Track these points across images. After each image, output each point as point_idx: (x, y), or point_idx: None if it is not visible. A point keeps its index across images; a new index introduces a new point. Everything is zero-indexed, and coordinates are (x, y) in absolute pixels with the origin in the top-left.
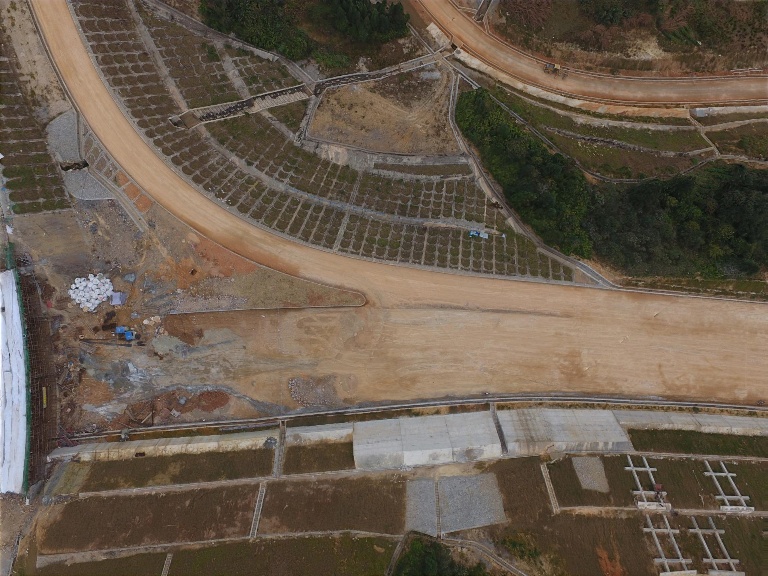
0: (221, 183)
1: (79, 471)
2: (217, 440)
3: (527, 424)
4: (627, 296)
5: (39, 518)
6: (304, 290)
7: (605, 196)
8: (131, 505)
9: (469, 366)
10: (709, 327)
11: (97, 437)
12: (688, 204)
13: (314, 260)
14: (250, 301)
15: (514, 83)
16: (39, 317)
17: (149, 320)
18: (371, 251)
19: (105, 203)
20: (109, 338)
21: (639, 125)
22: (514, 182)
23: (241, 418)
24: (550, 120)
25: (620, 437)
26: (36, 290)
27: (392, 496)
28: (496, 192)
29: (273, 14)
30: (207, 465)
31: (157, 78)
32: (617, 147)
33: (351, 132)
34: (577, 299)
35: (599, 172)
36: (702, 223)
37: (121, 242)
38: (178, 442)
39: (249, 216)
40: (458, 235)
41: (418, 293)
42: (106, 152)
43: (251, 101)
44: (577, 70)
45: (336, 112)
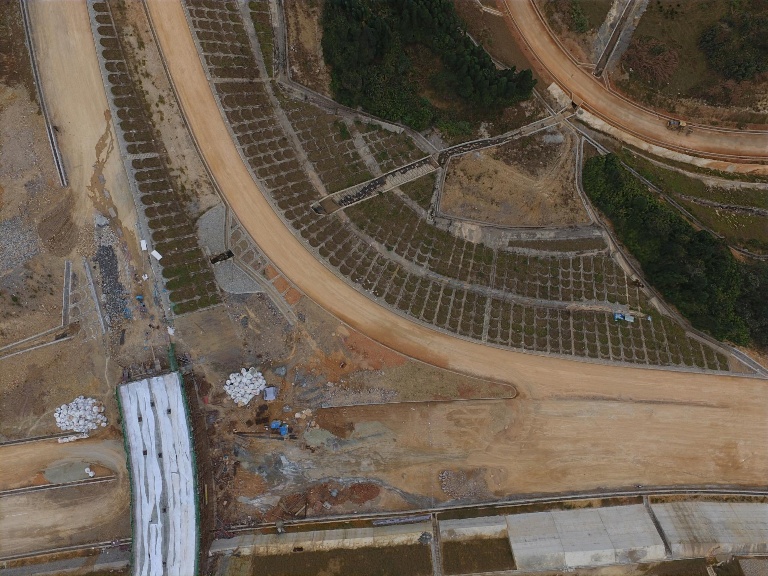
0: (366, 272)
1: (241, 567)
2: (372, 535)
3: (686, 521)
4: None
5: None
6: (454, 383)
7: (759, 278)
8: None
9: (621, 458)
10: None
11: (252, 529)
12: None
13: (463, 351)
14: (401, 394)
15: (639, 143)
16: (197, 413)
17: (301, 413)
18: (520, 341)
19: (255, 296)
20: (262, 431)
21: None
22: (656, 259)
23: (392, 510)
24: (683, 186)
25: None
26: (193, 387)
27: None
28: (634, 267)
29: (399, 85)
30: (366, 562)
31: (297, 164)
32: (756, 215)
33: (484, 208)
34: (734, 389)
35: (747, 248)
36: None
37: (271, 335)
38: (334, 536)
39: (397, 307)
40: (603, 319)
41: (569, 384)
42: (255, 246)
43: (383, 179)
44: (702, 125)
45: (465, 185)
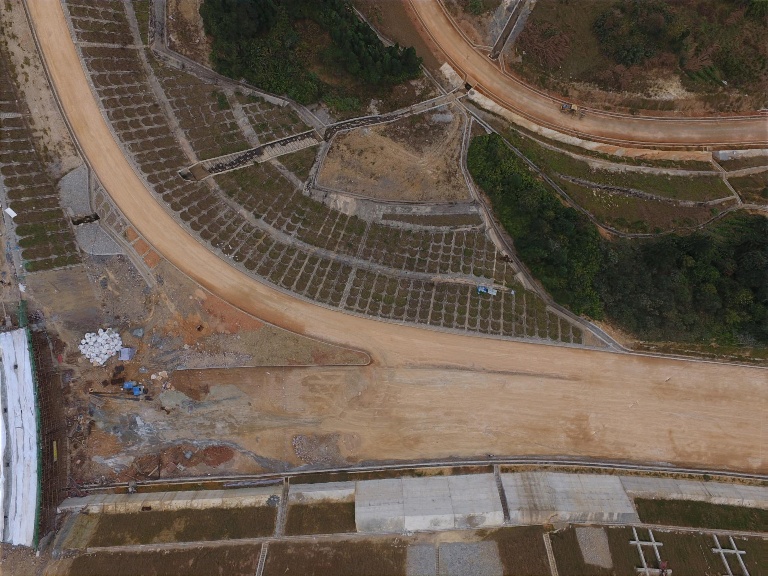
0: (229, 238)
1: (87, 524)
2: (221, 496)
3: None
4: (638, 360)
5: (48, 572)
6: (309, 348)
7: (619, 254)
8: (136, 562)
9: (474, 427)
10: (723, 393)
11: (105, 488)
12: (705, 264)
13: (320, 318)
14: (255, 358)
15: (529, 125)
16: (50, 371)
17: (156, 375)
18: (377, 309)
19: (115, 258)
20: (118, 392)
21: (658, 170)
22: (525, 235)
23: (245, 473)
24: (565, 167)
25: (626, 507)
26: (48, 345)
27: (392, 562)
28: (506, 244)
29: (284, 58)
30: (211, 522)
31: (167, 130)
32: (634, 196)
33: (360, 181)
34: (586, 362)
35: (613, 226)
36: (720, 284)
37: (130, 297)
38: (183, 497)
39: (256, 273)
40: (466, 291)
41: (423, 353)
42: (116, 208)
43: (260, 149)
44: (595, 110)
45: (346, 159)
